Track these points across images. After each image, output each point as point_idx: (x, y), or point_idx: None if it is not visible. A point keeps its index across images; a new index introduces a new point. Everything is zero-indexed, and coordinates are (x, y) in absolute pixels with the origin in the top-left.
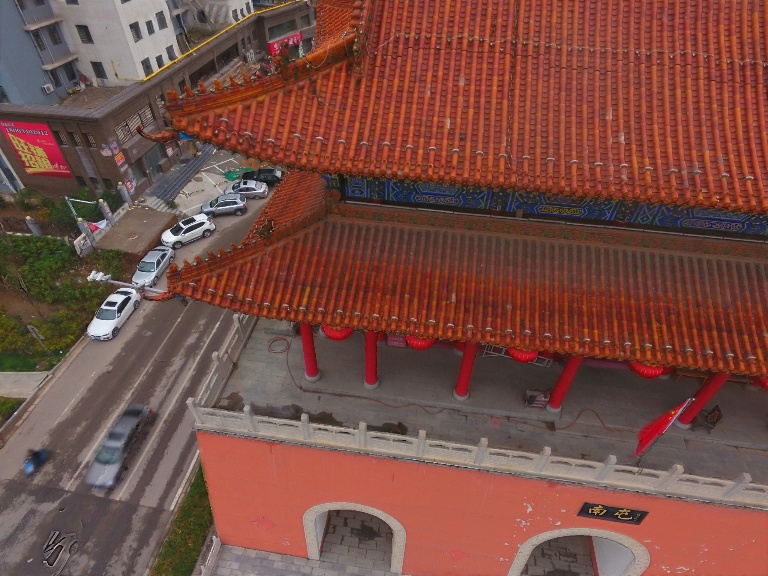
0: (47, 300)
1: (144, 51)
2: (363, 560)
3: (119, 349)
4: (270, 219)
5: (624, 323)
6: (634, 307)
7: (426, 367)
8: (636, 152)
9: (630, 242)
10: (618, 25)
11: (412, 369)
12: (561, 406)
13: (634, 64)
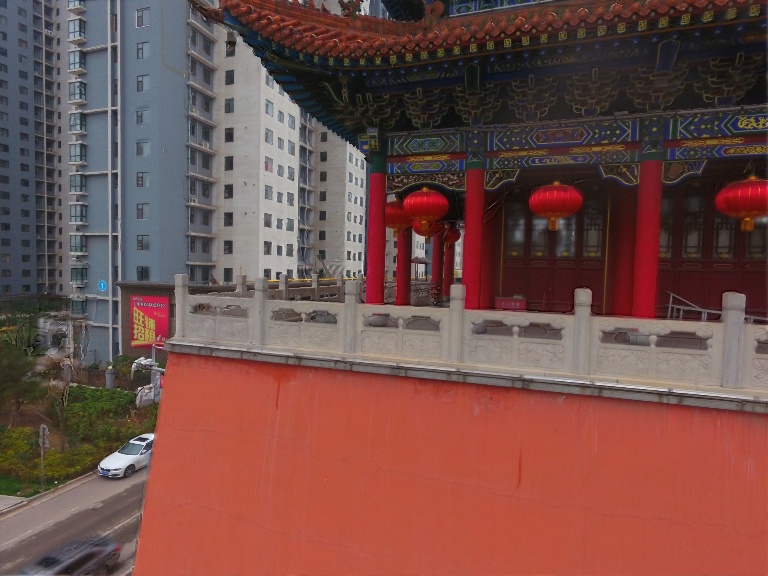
0: (79, 434)
1: (269, 263)
2: None
3: (123, 489)
4: None
5: None
6: None
7: None
8: None
9: None
10: None
11: (540, 331)
12: None
13: None
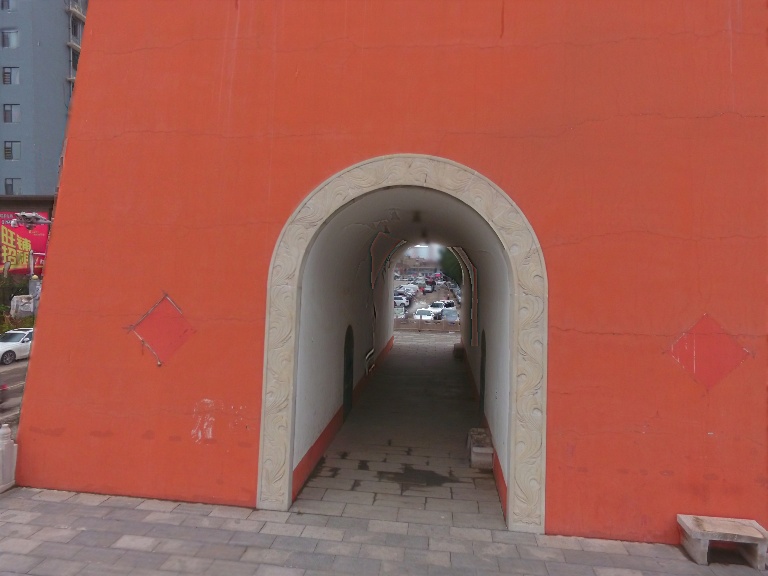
0: None
1: None
2: (419, 511)
3: (0, 371)
4: None
5: None
6: None
7: None
8: None
9: None
10: None
11: None
12: None
13: None
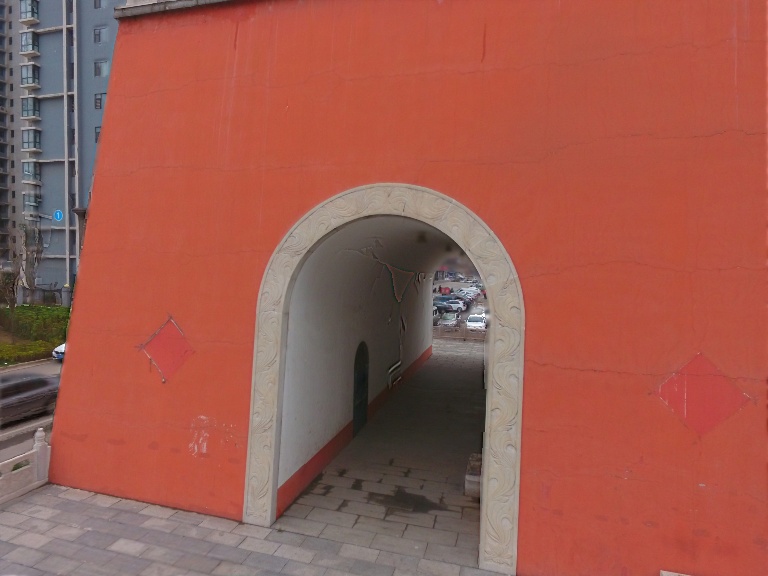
0: (32, 334)
1: None
2: (394, 539)
3: None
4: None
5: None
6: None
7: None
8: None
9: None
10: None
11: None
12: None
13: None
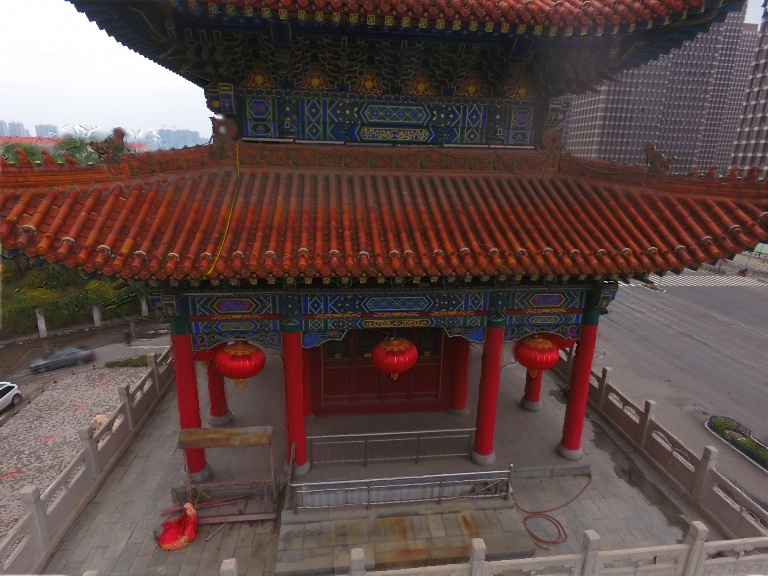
0: None
1: None
2: None
3: None
4: (649, 148)
5: None
6: None
7: (475, 376)
8: None
9: None
10: None
11: None
12: None
13: None
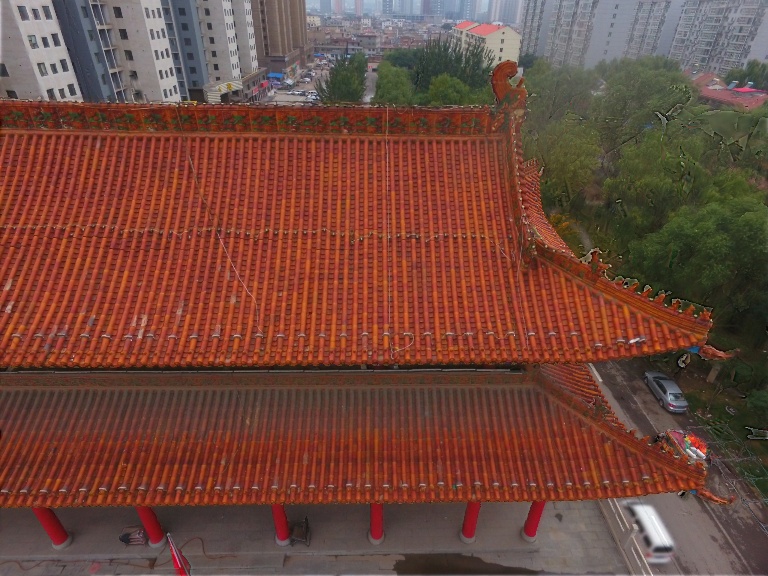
0: None
1: None
2: None
3: None
4: None
5: (90, 467)
6: (109, 448)
7: None
8: (20, 319)
9: (122, 383)
10: (45, 205)
11: (25, 518)
12: (165, 539)
13: (48, 238)
